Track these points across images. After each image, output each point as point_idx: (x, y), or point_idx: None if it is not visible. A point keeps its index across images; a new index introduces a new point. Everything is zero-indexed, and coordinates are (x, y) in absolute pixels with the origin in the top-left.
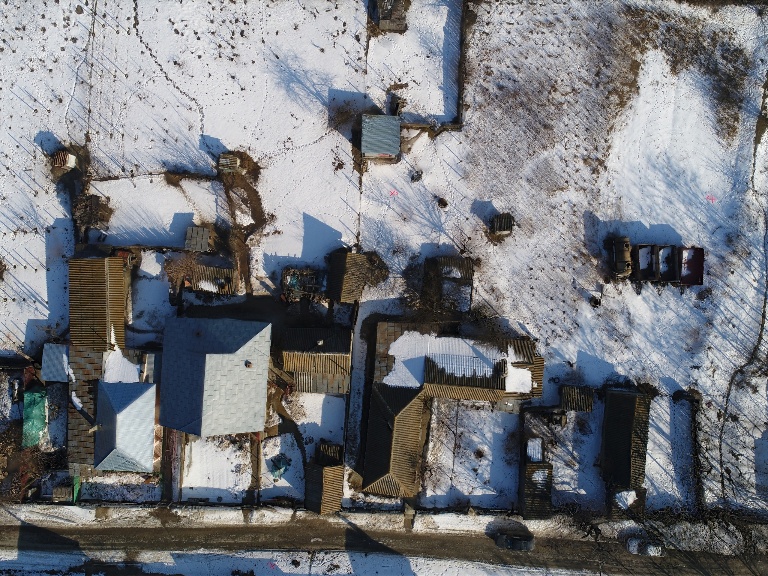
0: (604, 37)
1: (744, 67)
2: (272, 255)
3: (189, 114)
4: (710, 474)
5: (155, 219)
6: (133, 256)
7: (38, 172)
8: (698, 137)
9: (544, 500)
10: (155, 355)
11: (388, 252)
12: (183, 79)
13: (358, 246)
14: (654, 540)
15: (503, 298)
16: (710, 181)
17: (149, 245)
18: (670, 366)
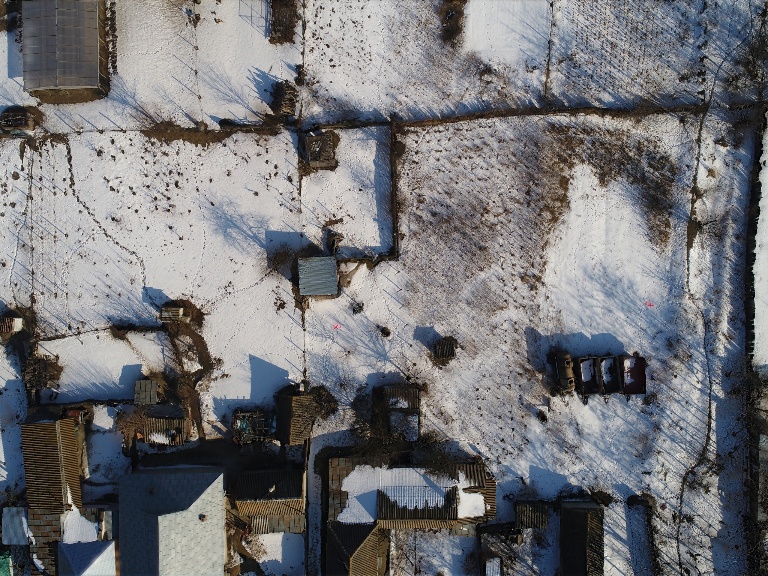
0: (531, 156)
1: (671, 174)
2: (221, 399)
3: (130, 268)
4: (670, 575)
5: (104, 374)
6: (85, 412)
7: None
8: (632, 245)
9: None
10: (112, 511)
11: (335, 386)
12: (122, 234)
13: (305, 382)
14: None
15: (452, 421)
16: (647, 287)
17: (100, 399)
18: (622, 472)
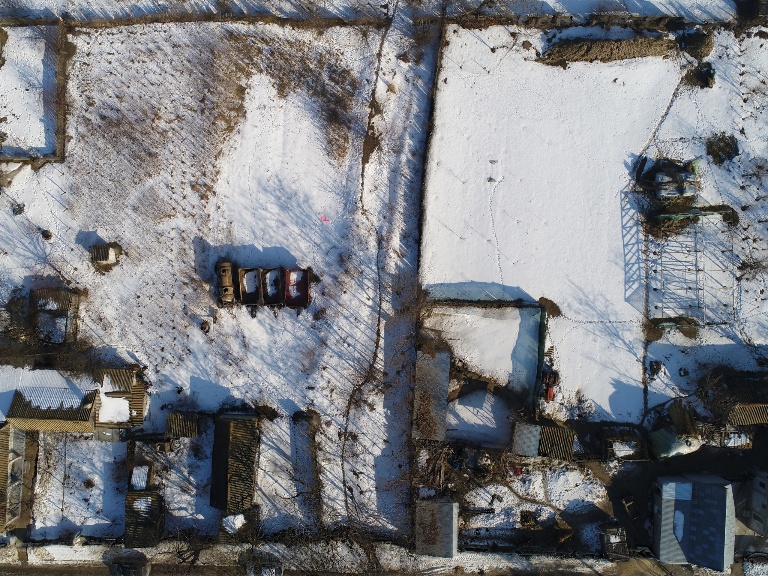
0: (207, 63)
1: (352, 88)
2: None
3: None
4: (333, 493)
5: None
6: None
7: None
8: (309, 159)
9: (148, 528)
10: None
11: None
12: None
13: None
14: (271, 562)
15: (111, 327)
16: (323, 202)
17: None
18: (288, 387)
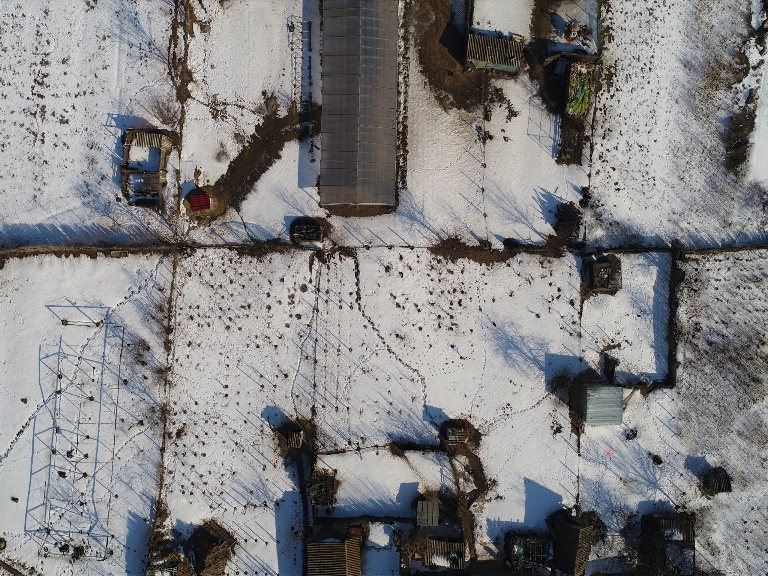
0: None
1: None
2: (495, 521)
3: (412, 385)
4: None
5: (382, 490)
6: None
7: (266, 446)
8: None
9: None
10: None
11: (607, 512)
12: (405, 351)
13: (577, 507)
14: None
15: (719, 552)
16: None
17: (376, 516)
18: None
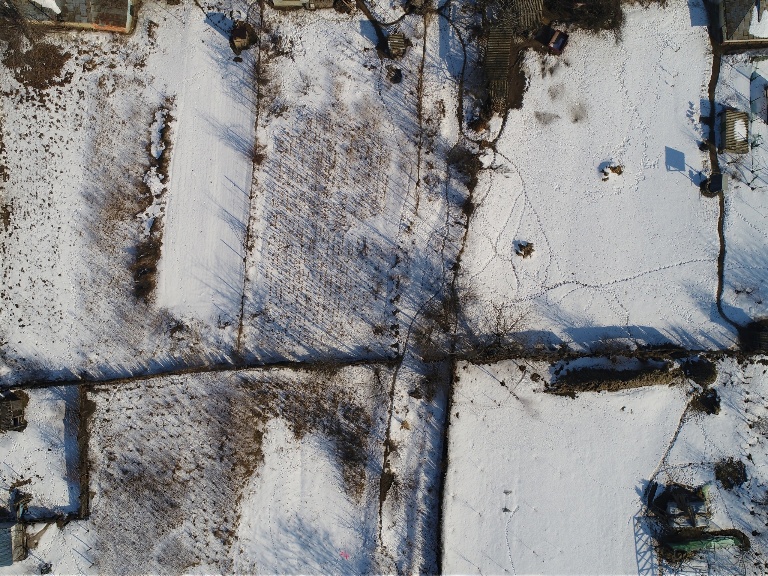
0: (224, 411)
1: (366, 425)
2: None
3: None
4: None
5: None
6: None
7: None
8: (327, 496)
9: None
10: None
11: None
12: None
13: None
14: None
15: None
16: (343, 538)
17: None
18: None
